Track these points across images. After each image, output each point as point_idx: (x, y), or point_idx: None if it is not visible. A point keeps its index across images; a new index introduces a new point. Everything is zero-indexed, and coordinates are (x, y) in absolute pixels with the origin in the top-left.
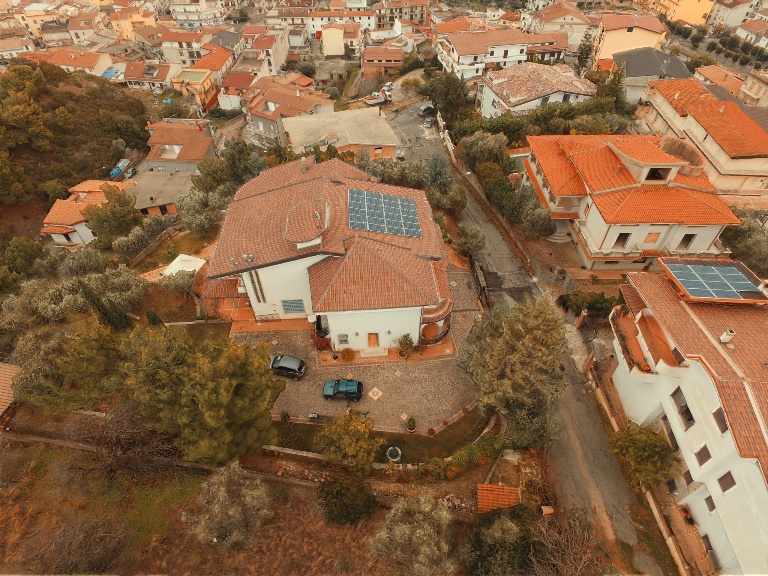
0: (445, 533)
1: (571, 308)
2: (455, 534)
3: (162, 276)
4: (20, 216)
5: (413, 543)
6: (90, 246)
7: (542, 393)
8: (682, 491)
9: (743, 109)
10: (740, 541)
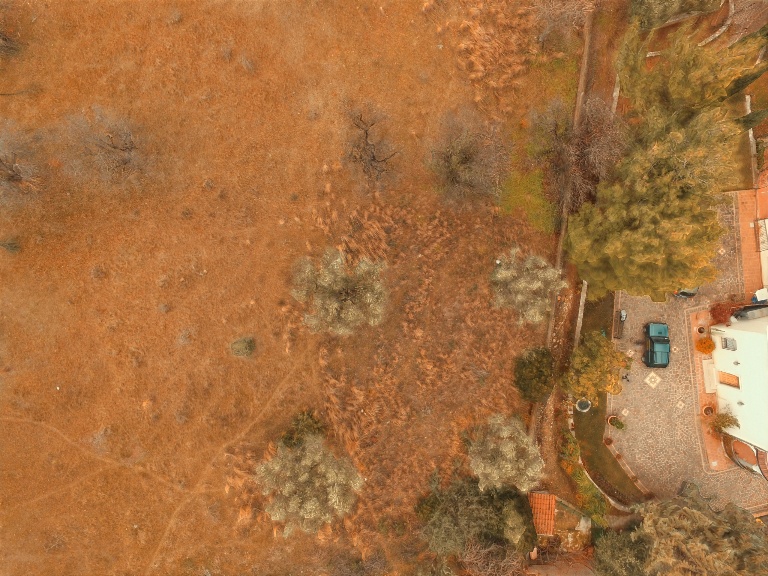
0: None
1: None
2: None
3: None
4: None
5: (500, 459)
6: None
7: None
8: None
9: None
10: None
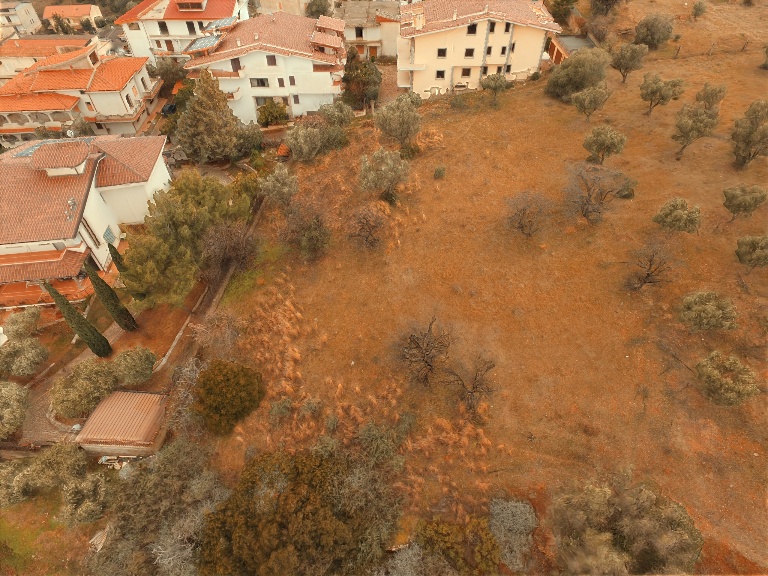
0: None
1: (171, 134)
2: None
3: None
4: None
5: None
6: None
7: (237, 122)
8: (290, 110)
9: (24, 39)
10: (312, 88)
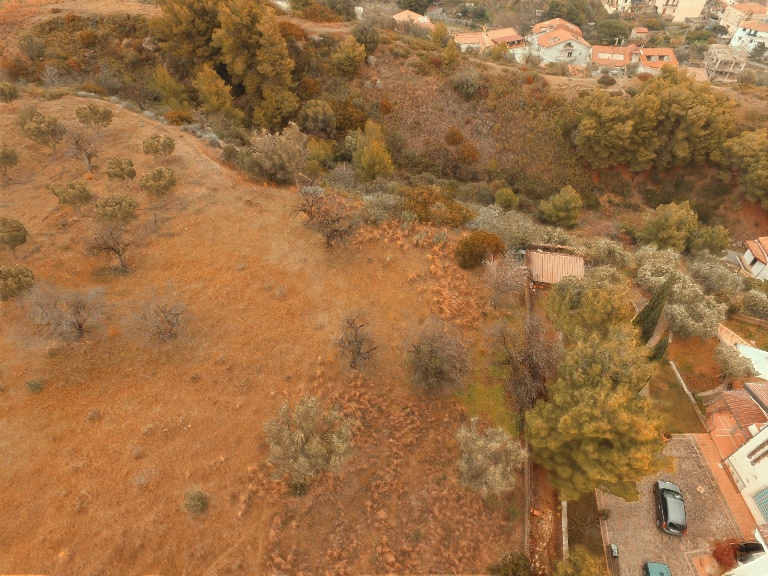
0: None
1: None
2: None
3: None
4: (755, 221)
5: None
6: (750, 281)
7: None
8: None
9: None
10: None
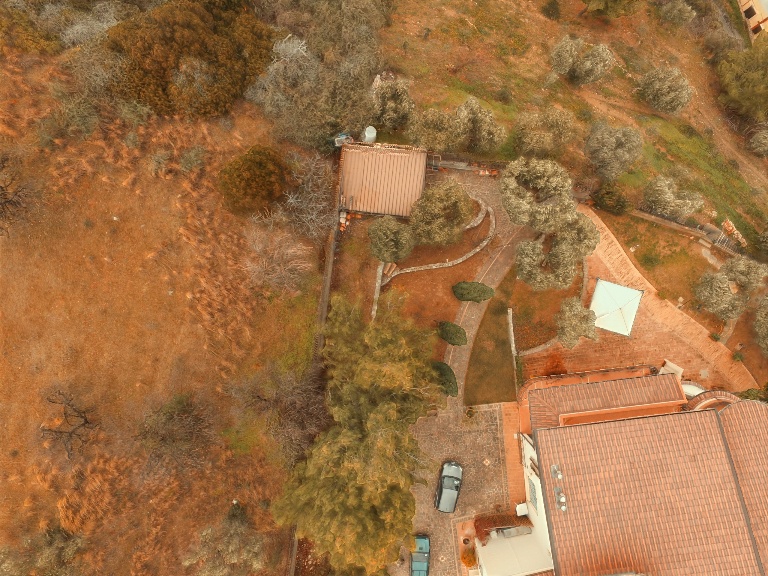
0: None
1: None
2: None
3: (608, 262)
4: None
5: None
6: (726, 45)
7: None
8: None
9: None
10: None
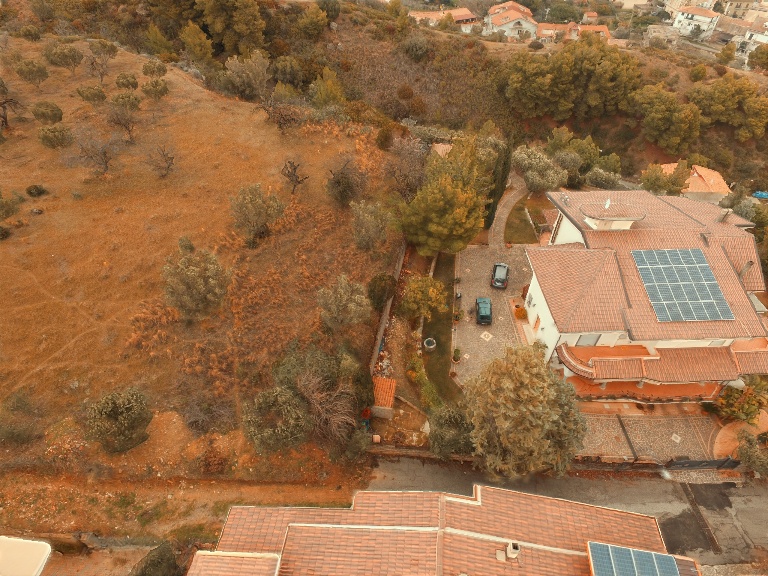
0: (361, 353)
1: None
2: (360, 360)
3: None
4: (655, 159)
5: None
6: None
7: None
8: None
9: None
10: None
